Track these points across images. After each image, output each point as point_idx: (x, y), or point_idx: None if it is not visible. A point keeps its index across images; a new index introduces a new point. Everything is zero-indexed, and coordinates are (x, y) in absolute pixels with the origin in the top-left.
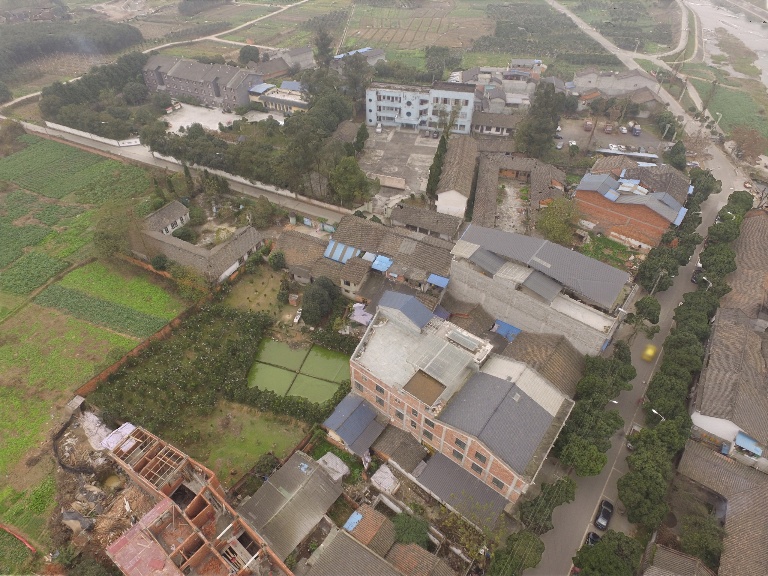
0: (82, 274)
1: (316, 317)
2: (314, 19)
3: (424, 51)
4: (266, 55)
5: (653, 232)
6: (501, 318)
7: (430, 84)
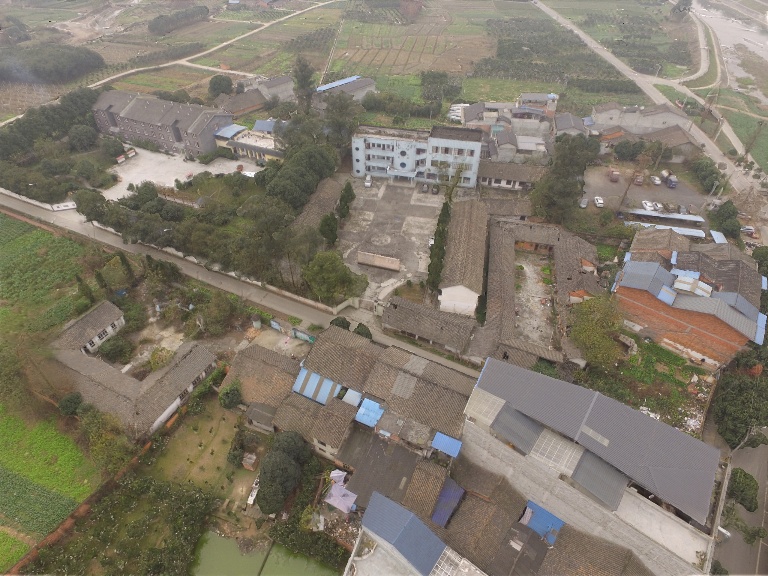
0: None
1: (277, 506)
2: (297, 39)
3: (419, 77)
4: (240, 85)
5: (723, 347)
6: (535, 500)
7: (427, 119)
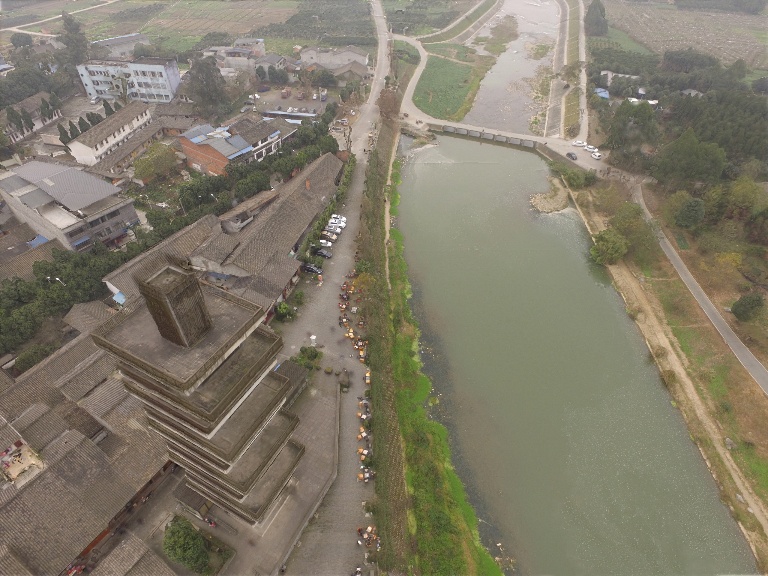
0: None
1: None
2: (125, 11)
3: None
4: (42, 42)
5: None
6: (38, 232)
7: (183, 64)
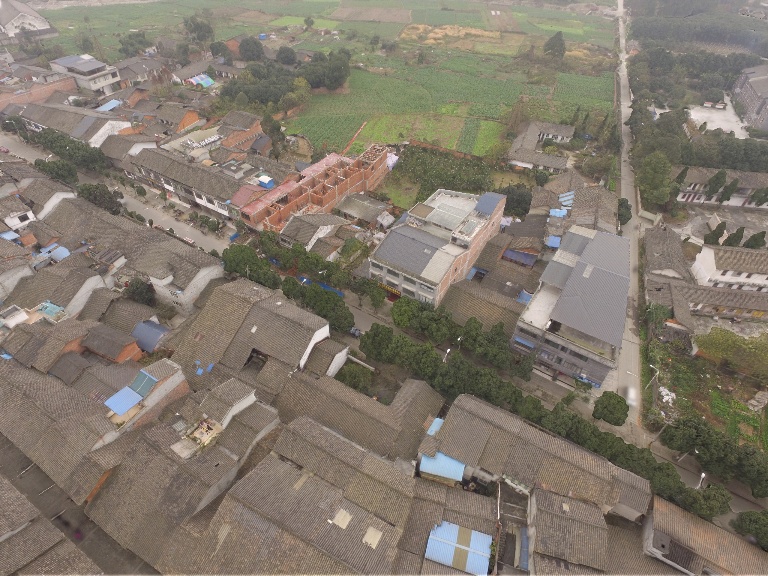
0: (493, 125)
1: None
2: None
3: None
4: None
5: None
6: None
7: None
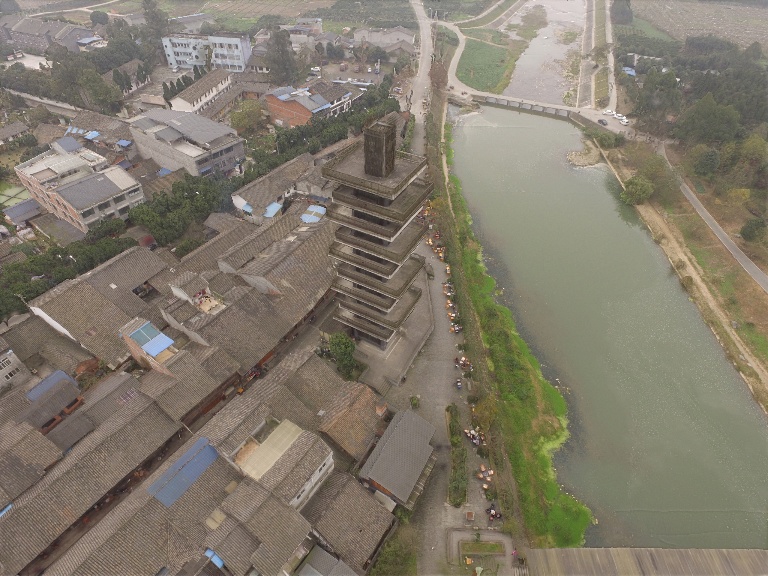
0: None
1: None
2: None
3: None
4: None
5: None
6: (163, 165)
7: None
